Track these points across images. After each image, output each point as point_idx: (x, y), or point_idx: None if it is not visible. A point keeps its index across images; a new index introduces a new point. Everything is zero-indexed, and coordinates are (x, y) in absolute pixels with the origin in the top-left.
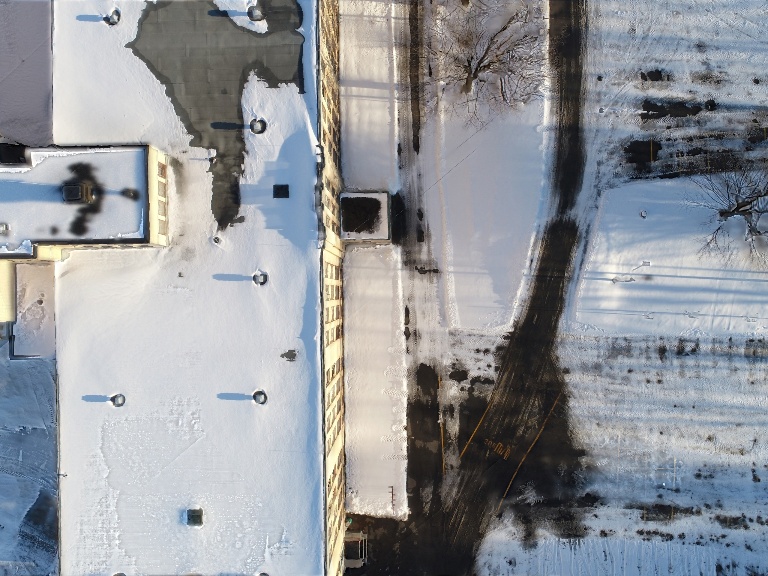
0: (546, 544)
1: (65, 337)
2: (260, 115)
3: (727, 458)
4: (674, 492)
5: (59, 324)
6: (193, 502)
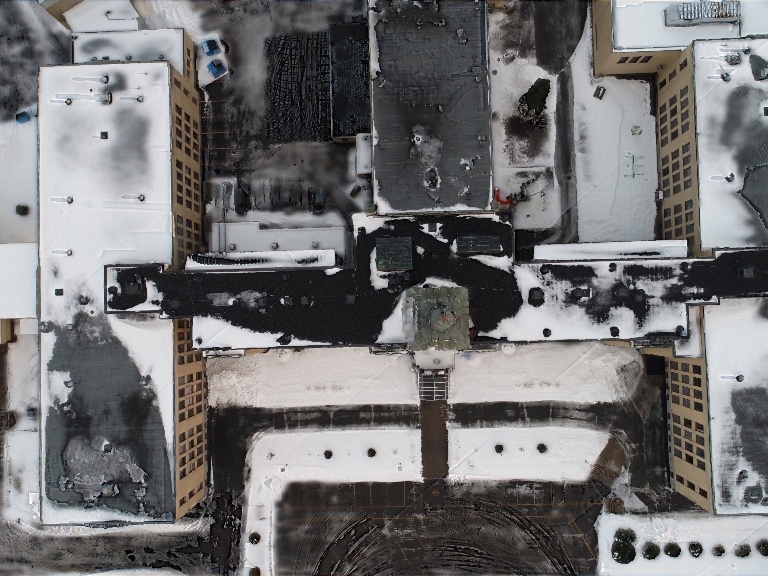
0: None
1: (711, 345)
2: None
3: None
4: None
5: (708, 338)
6: None
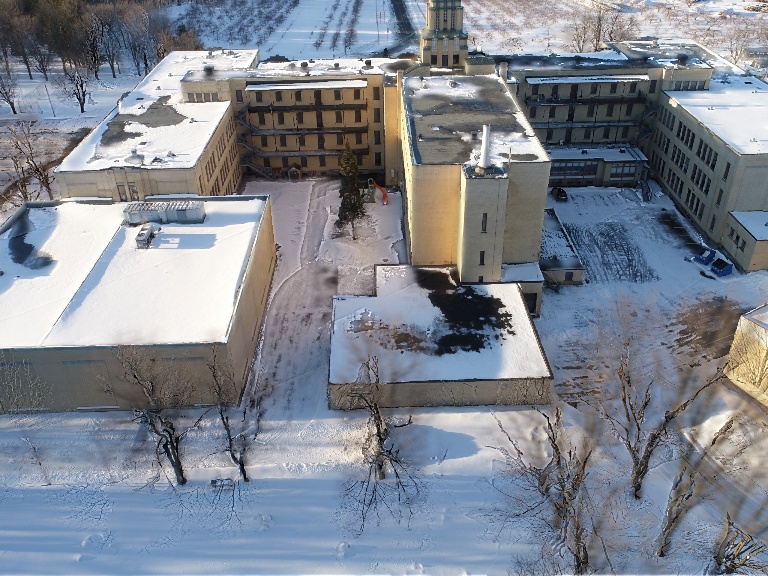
0: None
1: None
2: None
3: (8, 141)
4: (36, 135)
5: None
6: (205, 65)
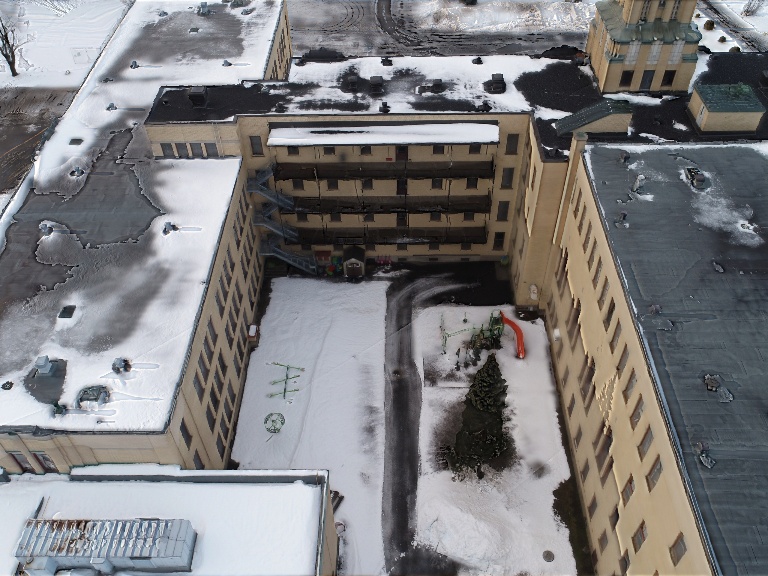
0: (35, 111)
1: None
2: (73, 178)
3: None
4: None
5: None
6: (194, 35)
